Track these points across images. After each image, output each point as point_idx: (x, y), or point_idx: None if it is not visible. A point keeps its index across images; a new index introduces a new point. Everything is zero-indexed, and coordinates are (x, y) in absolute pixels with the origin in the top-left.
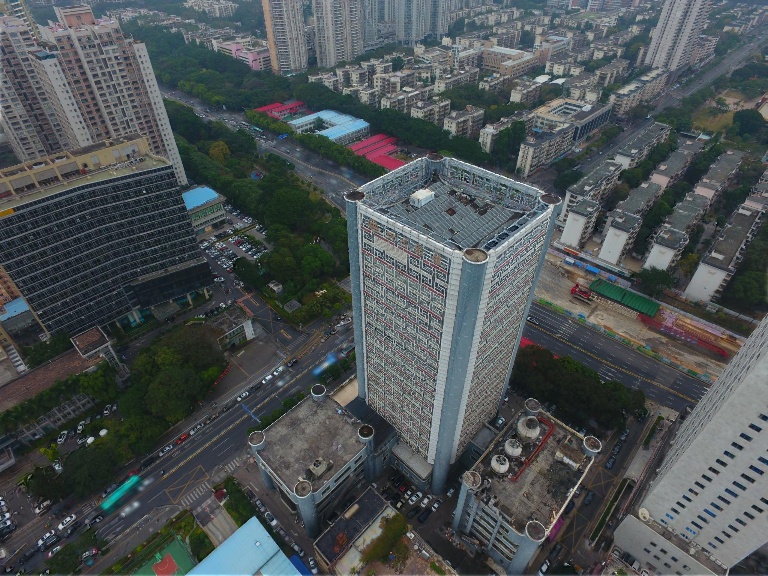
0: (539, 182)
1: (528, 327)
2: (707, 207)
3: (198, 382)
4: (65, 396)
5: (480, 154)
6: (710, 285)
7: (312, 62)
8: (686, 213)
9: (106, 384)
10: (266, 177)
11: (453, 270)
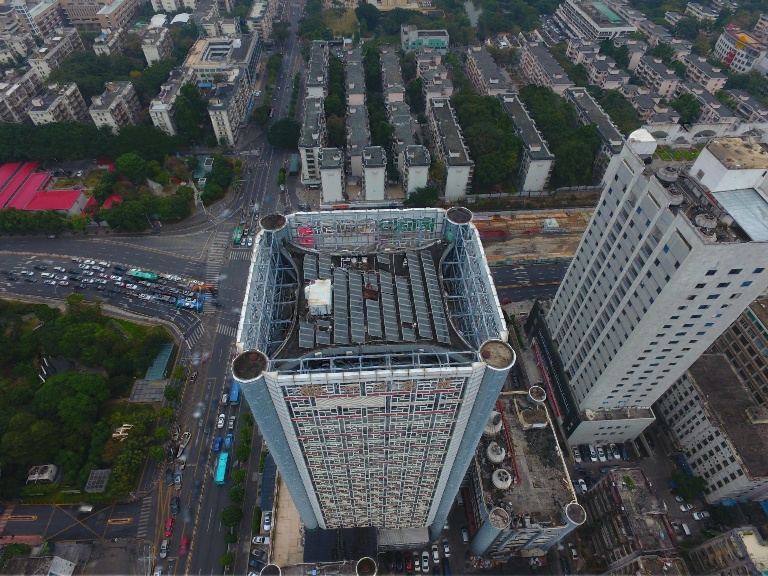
0: (250, 144)
1: None
2: None
3: None
4: None
5: (169, 140)
6: (461, 182)
7: None
8: (403, 124)
9: None
10: None
11: (472, 385)
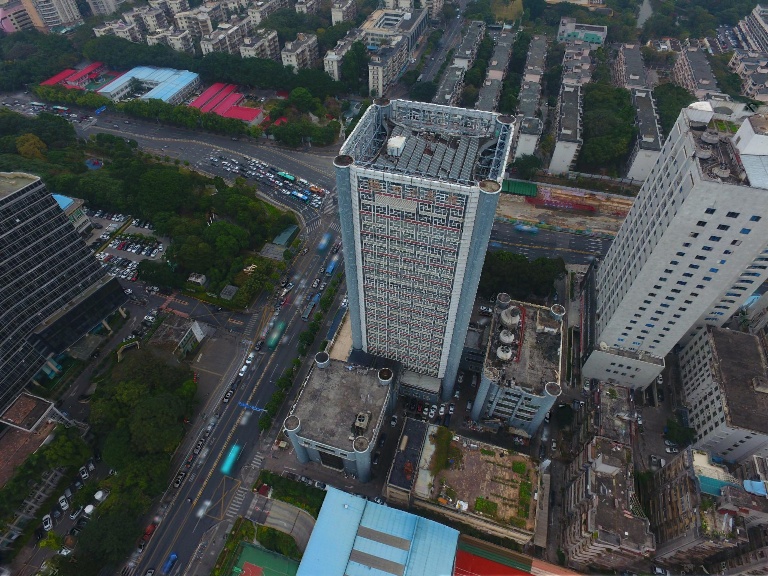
0: None
1: None
2: (540, 91)
3: (180, 402)
4: (35, 480)
5: (333, 84)
6: (567, 157)
7: (82, 9)
8: (529, 101)
9: (75, 447)
10: (111, 163)
11: (470, 205)
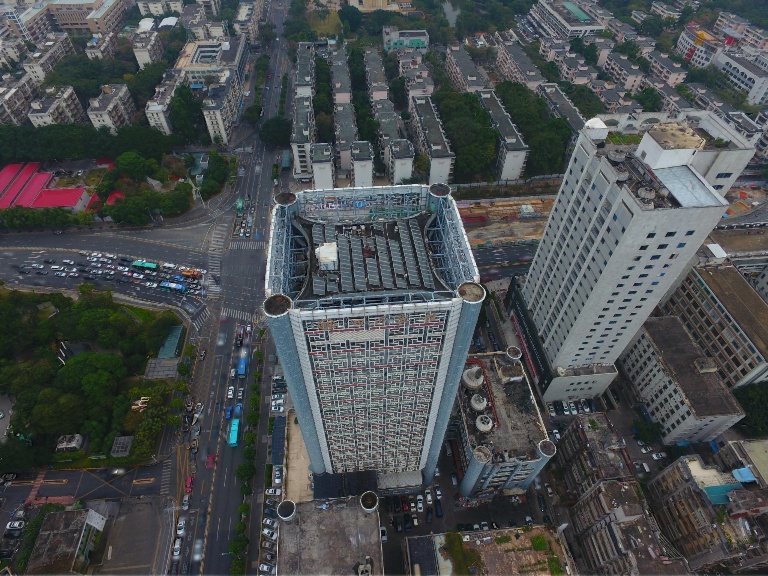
0: (242, 142)
1: None
2: None
3: None
4: None
5: (166, 139)
6: (443, 172)
7: None
8: (388, 120)
9: None
10: None
11: (453, 318)
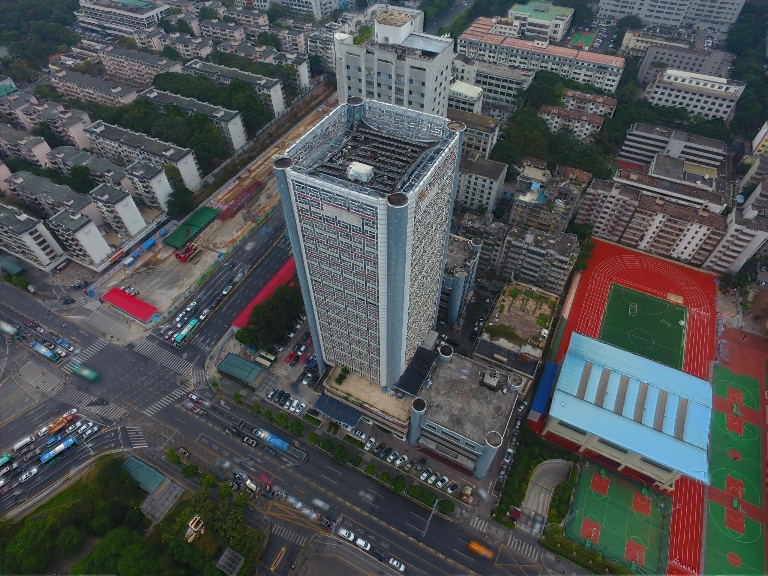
0: None
1: (237, 293)
2: None
3: None
4: None
5: None
6: (192, 170)
7: None
8: (89, 161)
9: None
10: None
11: None
